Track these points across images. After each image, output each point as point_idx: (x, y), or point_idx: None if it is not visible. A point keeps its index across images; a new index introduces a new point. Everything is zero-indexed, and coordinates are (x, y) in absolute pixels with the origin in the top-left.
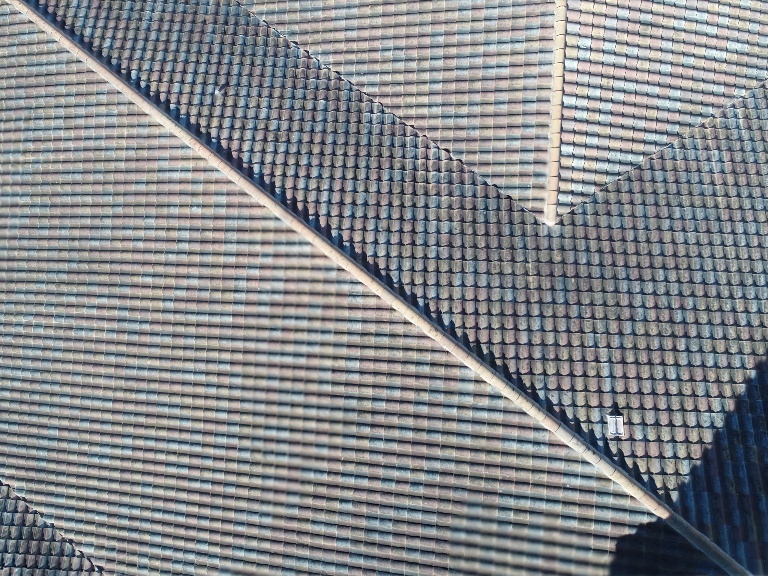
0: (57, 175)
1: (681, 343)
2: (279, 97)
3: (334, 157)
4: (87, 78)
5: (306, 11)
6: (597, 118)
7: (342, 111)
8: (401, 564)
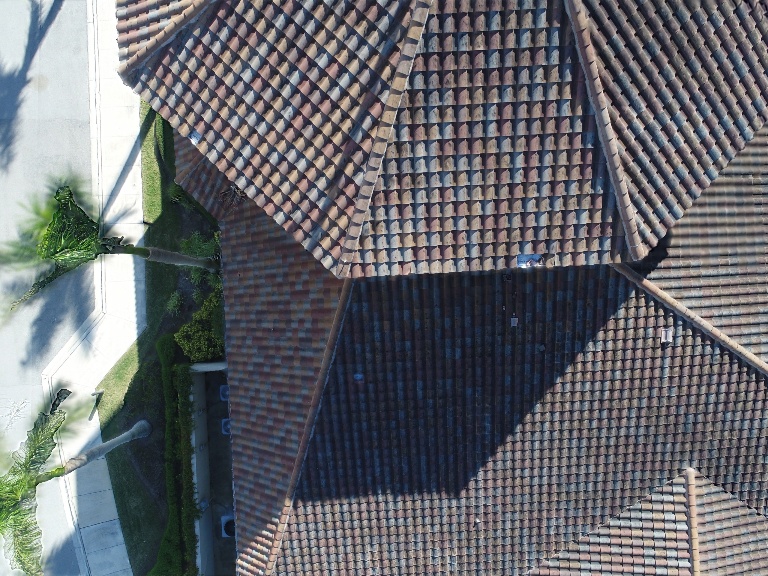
0: None
1: (607, 396)
2: None
3: None
4: None
5: None
6: (657, 552)
7: None
8: None
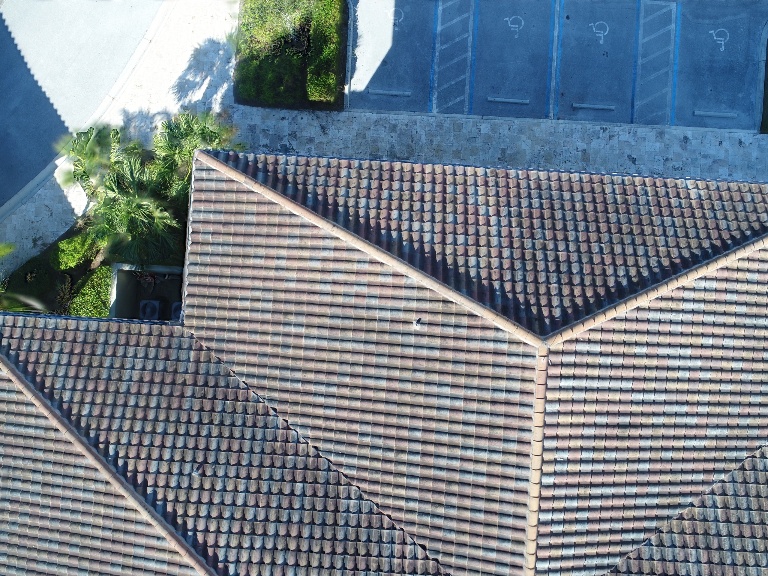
0: (34, 541)
1: None
2: (257, 478)
3: (310, 554)
4: (65, 448)
5: (286, 381)
6: (573, 529)
7: (319, 497)
8: None
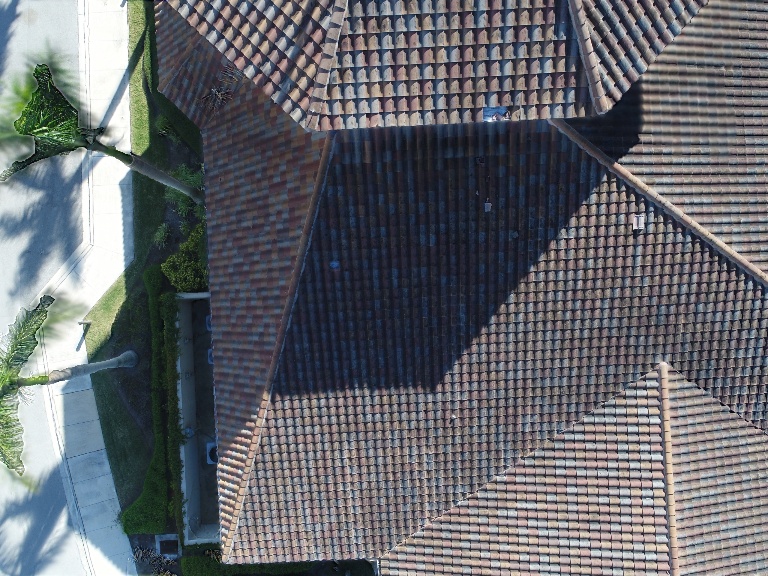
0: None
1: (581, 285)
2: None
3: None
4: None
5: None
6: (630, 446)
7: None
8: (764, 105)
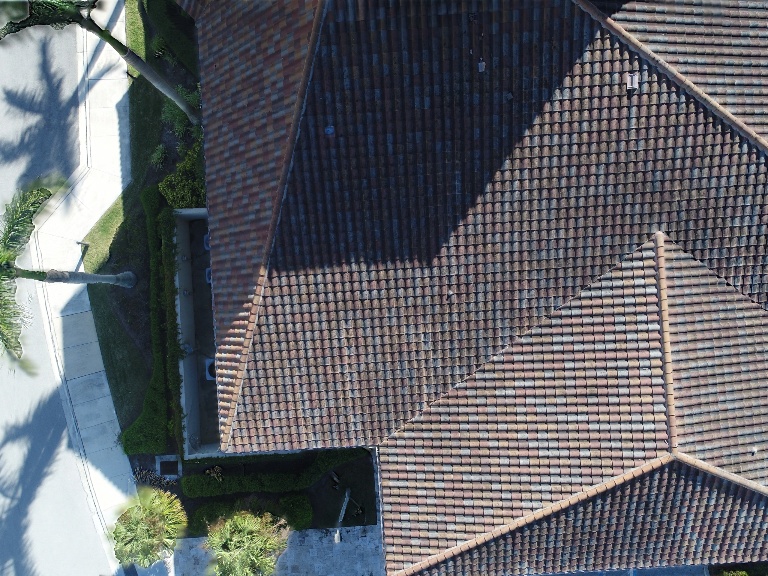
0: None
1: (575, 150)
2: None
3: None
4: None
5: None
6: (627, 318)
7: None
8: None
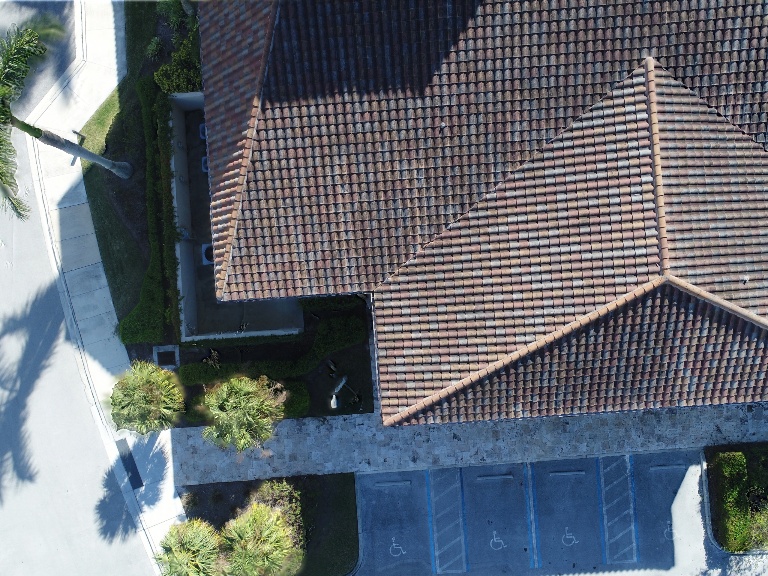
0: None
1: None
2: None
3: None
4: None
5: None
6: (618, 145)
7: None
8: None
